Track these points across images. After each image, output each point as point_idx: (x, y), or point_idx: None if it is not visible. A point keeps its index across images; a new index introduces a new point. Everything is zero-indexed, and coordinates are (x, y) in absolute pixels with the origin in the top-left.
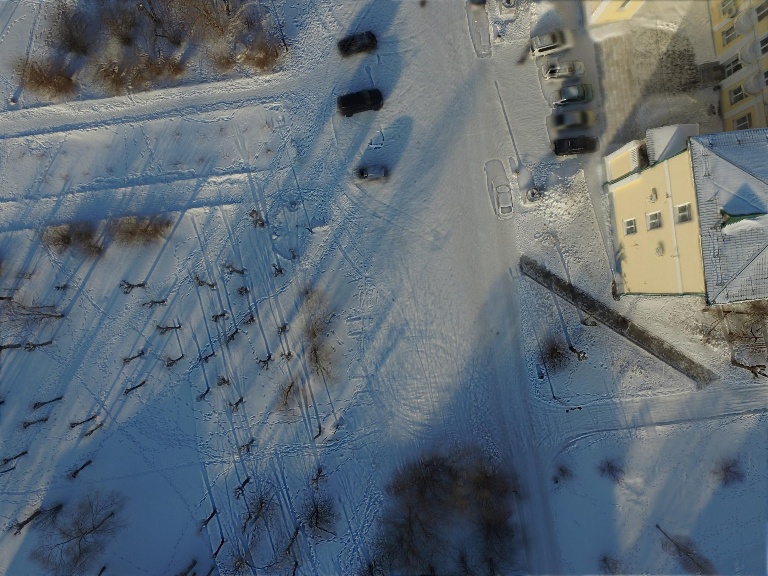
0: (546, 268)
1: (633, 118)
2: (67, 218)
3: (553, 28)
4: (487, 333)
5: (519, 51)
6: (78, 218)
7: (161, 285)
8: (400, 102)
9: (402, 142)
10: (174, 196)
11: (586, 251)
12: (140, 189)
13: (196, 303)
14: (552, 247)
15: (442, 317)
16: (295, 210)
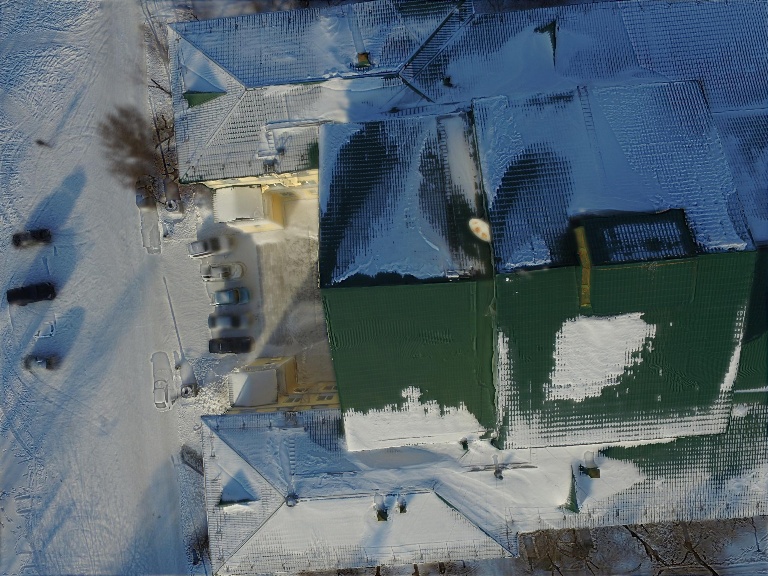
0: None
1: (284, 323)
2: None
3: (217, 230)
4: (149, 516)
5: None
6: None
7: None
8: (73, 293)
9: (74, 331)
10: None
11: None
12: None
13: None
14: None
15: (107, 499)
16: None
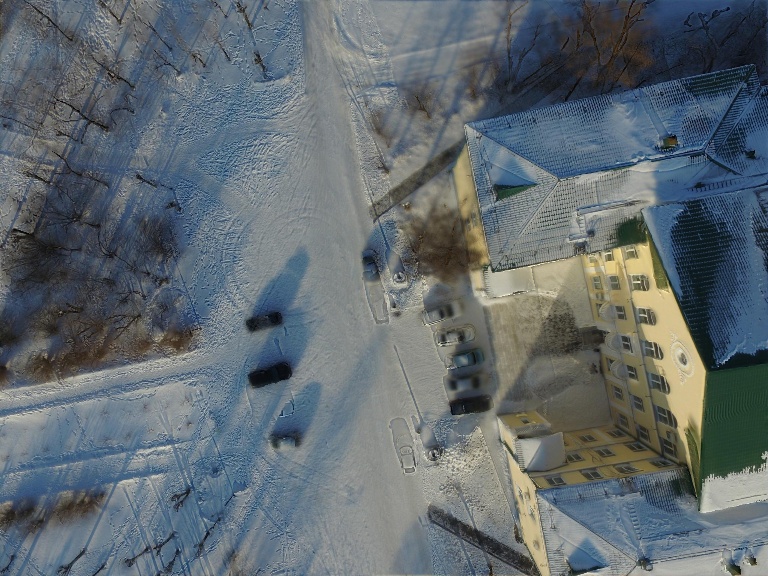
0: (452, 516)
1: (522, 379)
2: (10, 495)
3: (444, 295)
4: None
5: (414, 317)
6: (20, 494)
7: (100, 551)
8: (308, 370)
9: (312, 406)
10: (106, 469)
11: (488, 500)
12: (75, 465)
13: (133, 566)
14: (456, 497)
15: (360, 565)
16: (218, 476)
